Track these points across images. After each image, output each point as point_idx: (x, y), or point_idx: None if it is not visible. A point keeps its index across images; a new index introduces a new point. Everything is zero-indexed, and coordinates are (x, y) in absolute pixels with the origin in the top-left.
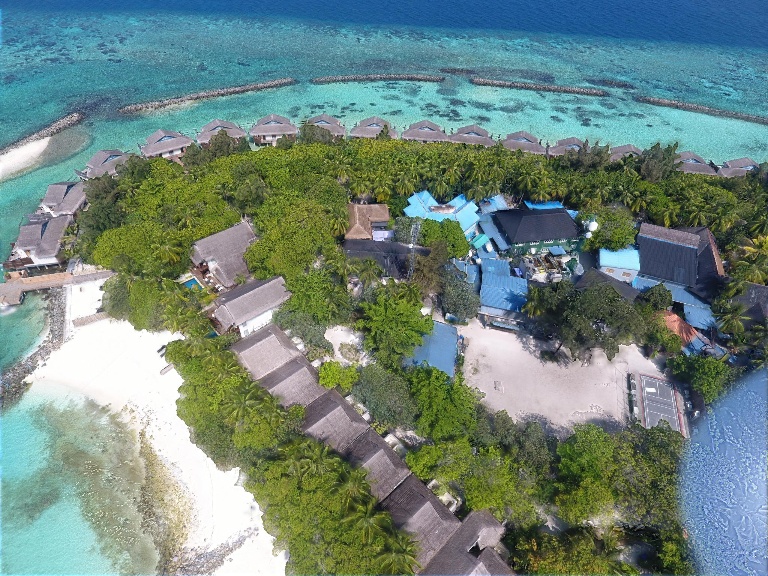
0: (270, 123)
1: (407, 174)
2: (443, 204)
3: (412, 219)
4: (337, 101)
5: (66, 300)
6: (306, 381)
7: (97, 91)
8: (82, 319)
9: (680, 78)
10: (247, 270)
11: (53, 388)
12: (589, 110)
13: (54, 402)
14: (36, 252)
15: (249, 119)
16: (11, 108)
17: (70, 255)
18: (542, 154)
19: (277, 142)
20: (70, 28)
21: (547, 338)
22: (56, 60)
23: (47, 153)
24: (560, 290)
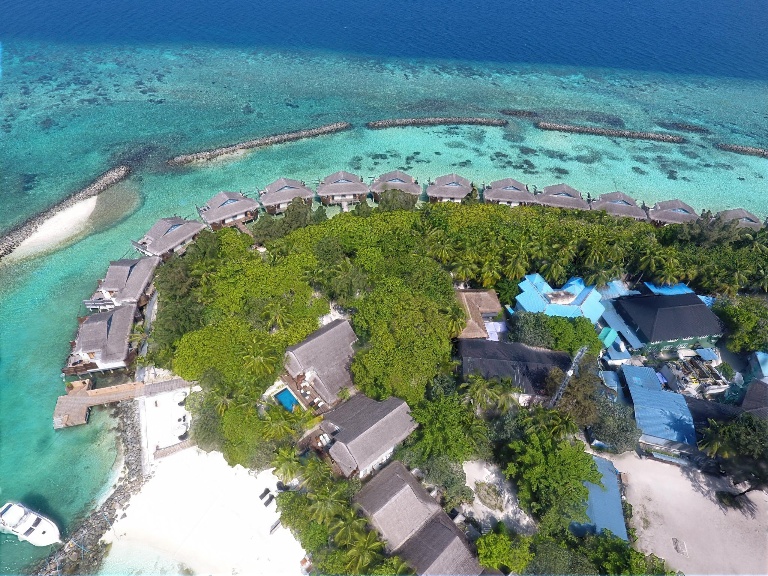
0: (339, 181)
1: (520, 257)
2: (558, 289)
3: (538, 317)
4: (399, 150)
5: (140, 419)
6: (460, 557)
7: (141, 138)
8: (164, 450)
9: (755, 121)
10: (351, 381)
11: (138, 551)
12: (671, 160)
13: (141, 573)
14: (102, 356)
15: (309, 172)
16: (51, 159)
17: (144, 364)
18: (643, 219)
19: (356, 209)
20: (104, 63)
21: (719, 473)
22: (94, 101)
23: (96, 216)
24: (759, 432)
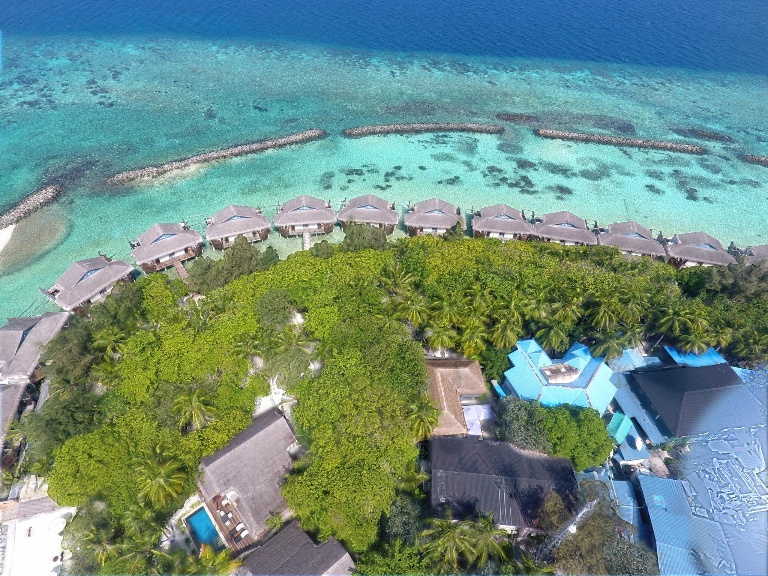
0: (301, 208)
1: (510, 322)
2: (558, 361)
3: (532, 412)
4: (378, 163)
5: (5, 556)
6: None
7: (81, 150)
8: None
9: None
10: (285, 501)
11: None
12: (690, 175)
13: None
14: None
15: (271, 192)
16: None
17: (13, 481)
18: (661, 255)
19: (314, 249)
20: (56, 59)
21: None
22: (35, 104)
23: (8, 252)
24: None
